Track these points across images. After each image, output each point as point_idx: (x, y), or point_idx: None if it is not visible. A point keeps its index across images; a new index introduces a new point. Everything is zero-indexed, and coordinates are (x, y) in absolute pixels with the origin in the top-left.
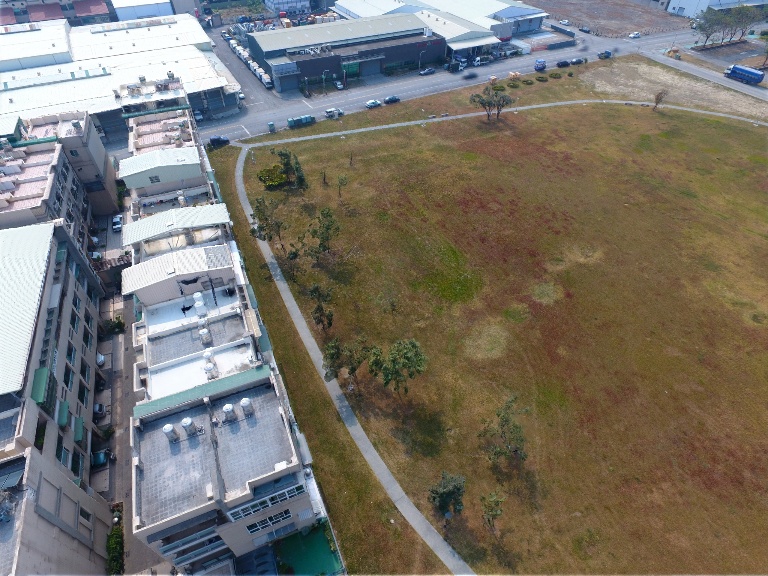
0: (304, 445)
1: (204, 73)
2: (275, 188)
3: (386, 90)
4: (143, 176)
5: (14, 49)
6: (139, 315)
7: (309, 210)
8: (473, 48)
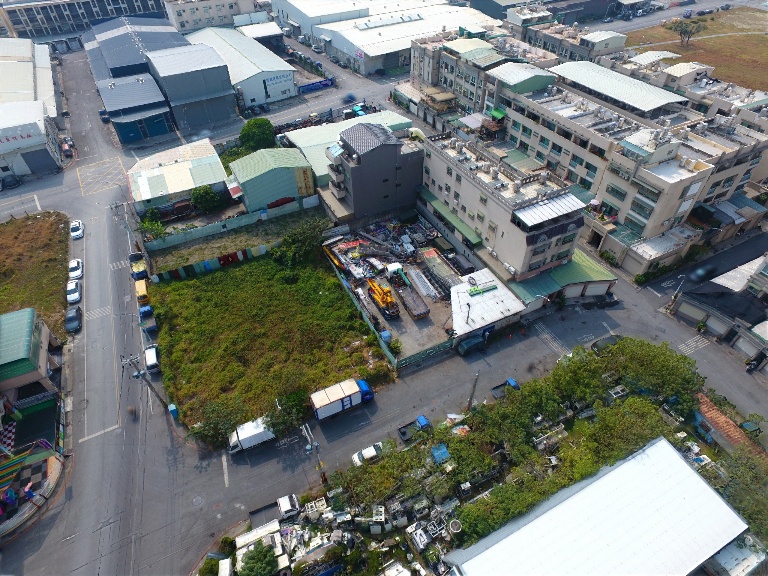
0: None
1: (483, 17)
2: None
3: (592, 31)
4: (604, 43)
5: (330, 7)
6: (677, 91)
7: None
8: (631, 4)
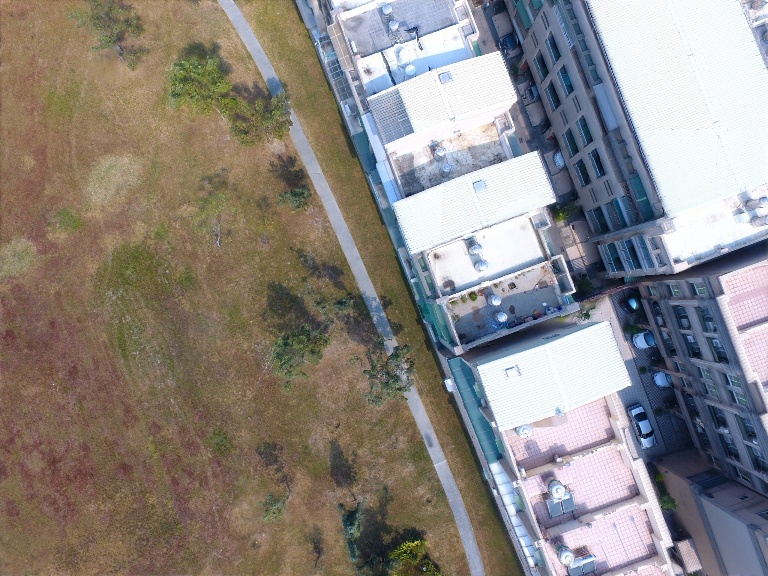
0: (305, 15)
1: None
2: (407, 537)
3: None
4: None
5: None
6: None
7: (343, 467)
8: None
